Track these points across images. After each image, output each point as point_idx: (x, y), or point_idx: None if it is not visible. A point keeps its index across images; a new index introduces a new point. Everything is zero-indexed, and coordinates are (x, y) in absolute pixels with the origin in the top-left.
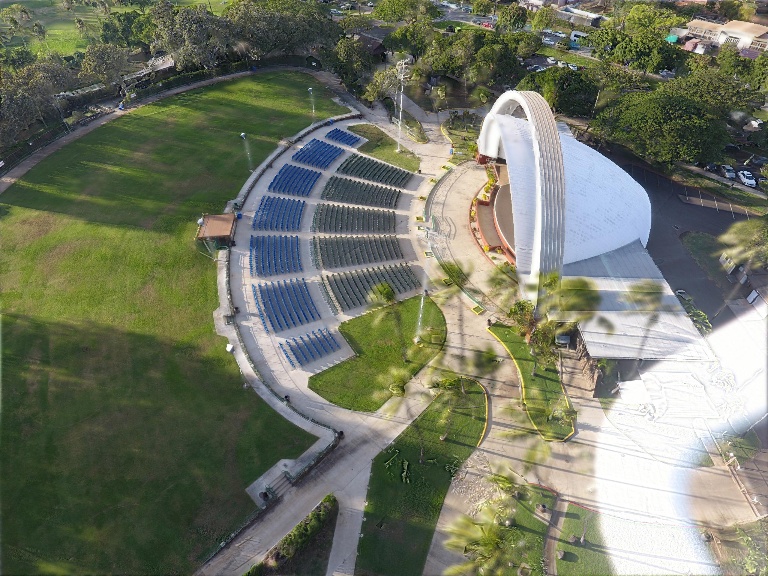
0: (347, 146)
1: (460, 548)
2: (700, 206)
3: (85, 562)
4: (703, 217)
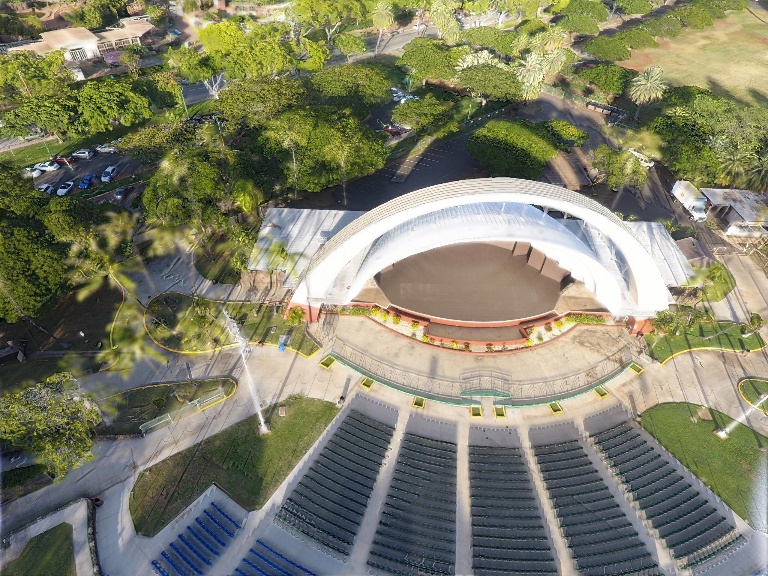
0: (236, 535)
1: None
2: (410, 175)
3: None
4: (426, 179)
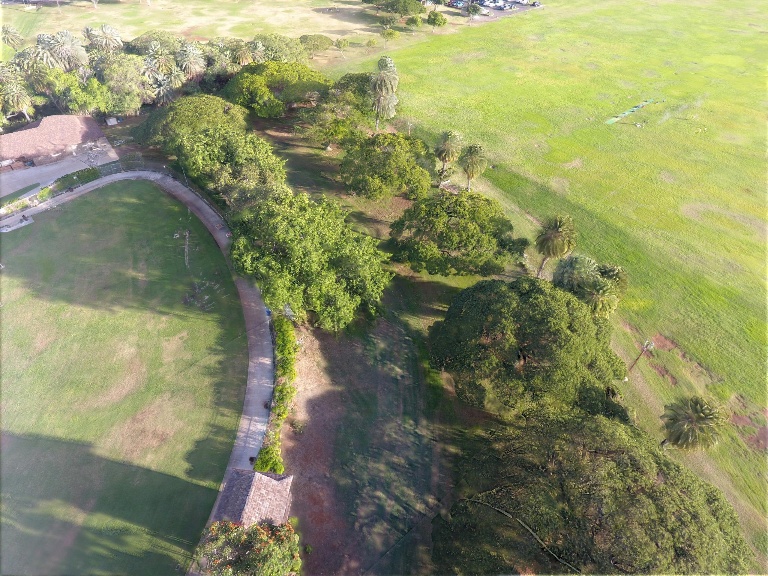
0: None
1: None
2: None
3: (114, 200)
4: None
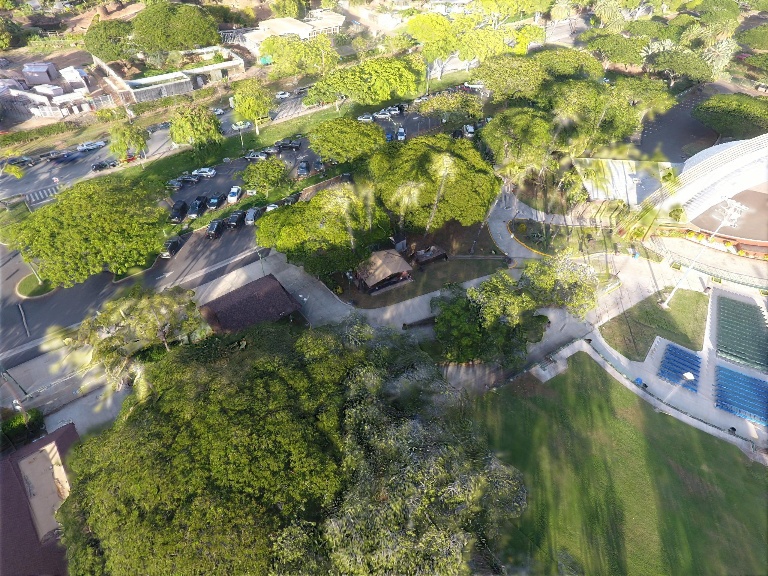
0: None
1: None
2: (643, 140)
3: None
4: (658, 143)
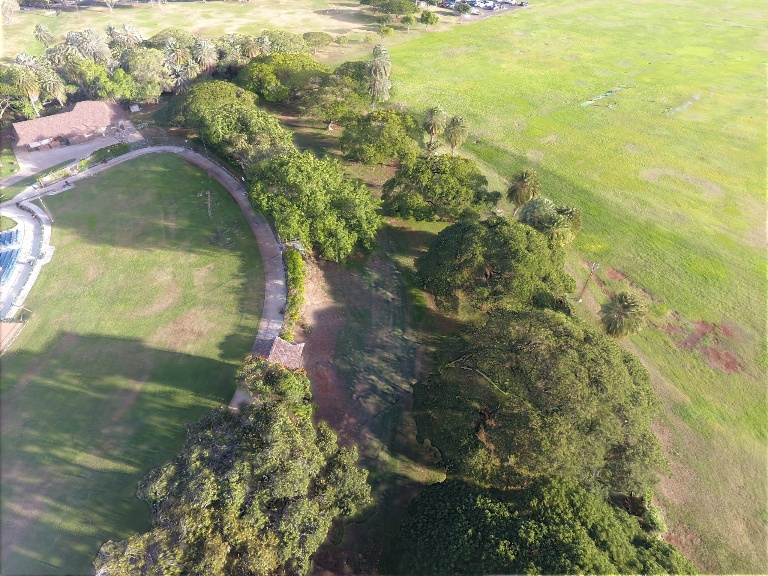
0: None
1: (2, 183)
2: None
3: None
4: None
